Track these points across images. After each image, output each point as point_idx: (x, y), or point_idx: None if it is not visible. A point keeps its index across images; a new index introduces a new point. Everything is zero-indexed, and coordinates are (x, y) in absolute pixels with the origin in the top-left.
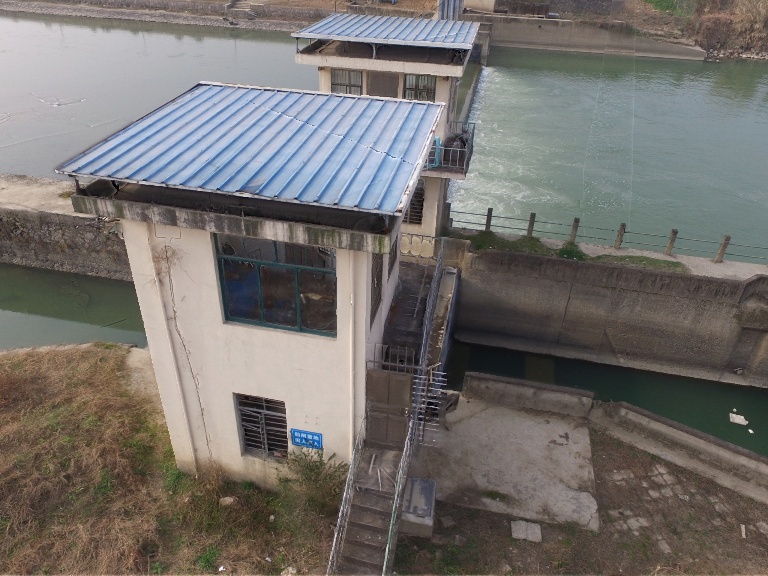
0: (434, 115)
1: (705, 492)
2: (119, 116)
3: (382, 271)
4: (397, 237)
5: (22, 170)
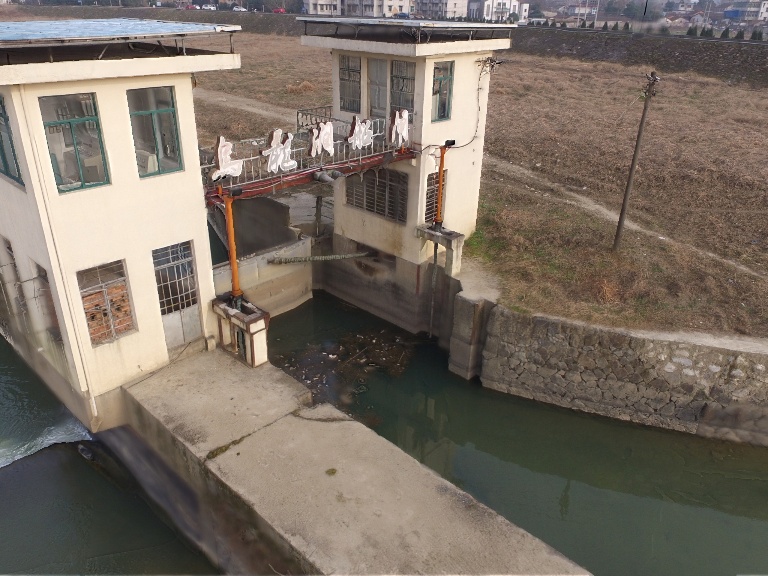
0: None
1: None
2: None
3: None
4: None
5: None
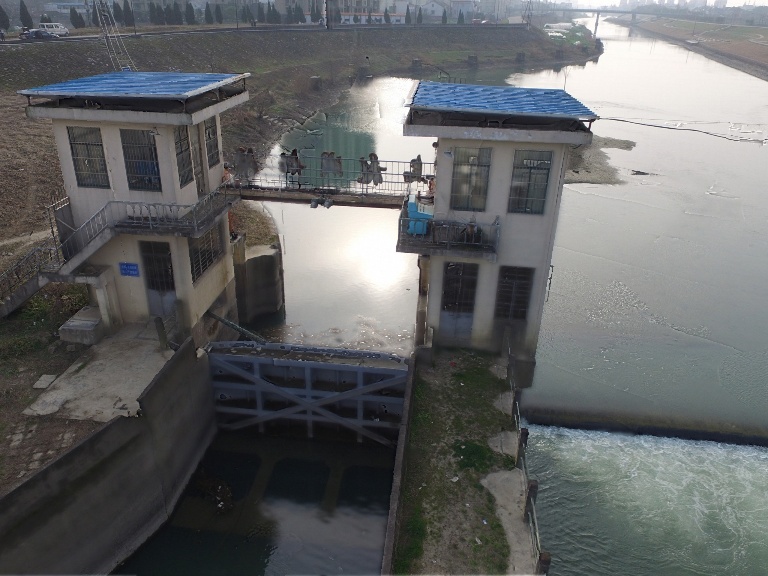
0: None
1: None
2: (724, 216)
3: (108, 168)
4: (160, 175)
5: (571, 209)
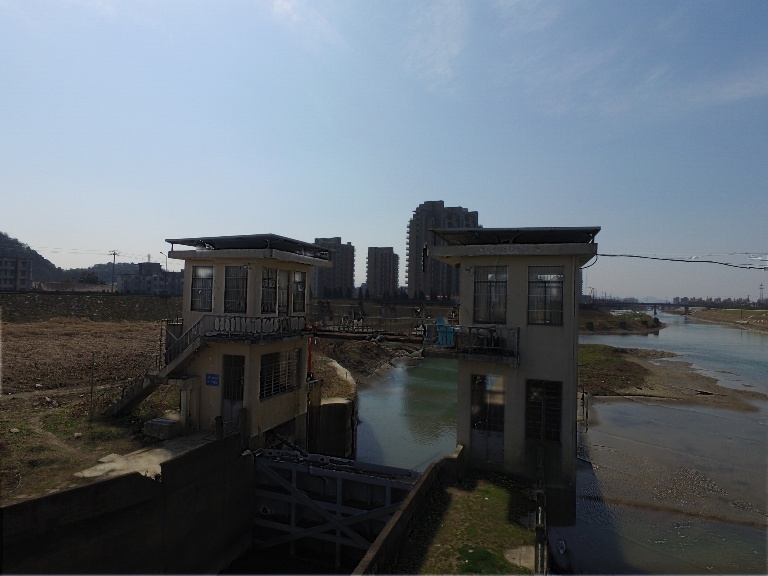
0: None
1: None
2: None
3: None
4: (247, 300)
5: (635, 413)
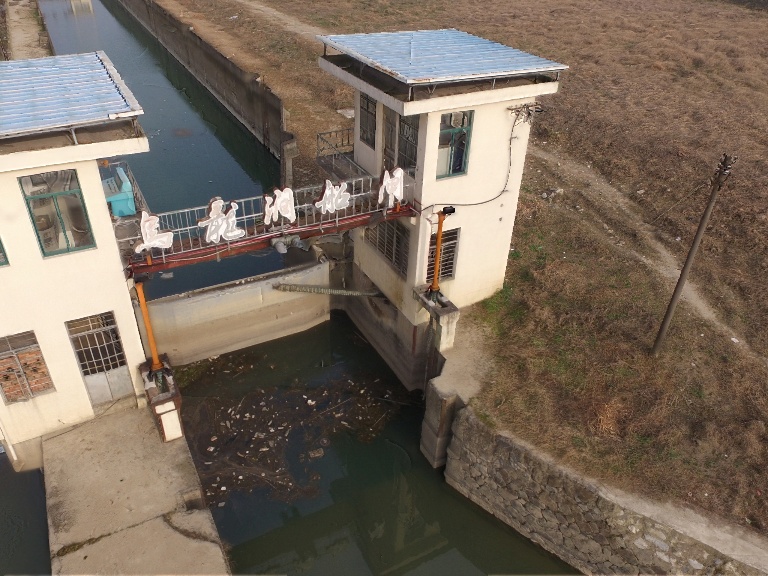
0: (341, 36)
1: (302, 182)
2: None
3: None
4: None
5: None
